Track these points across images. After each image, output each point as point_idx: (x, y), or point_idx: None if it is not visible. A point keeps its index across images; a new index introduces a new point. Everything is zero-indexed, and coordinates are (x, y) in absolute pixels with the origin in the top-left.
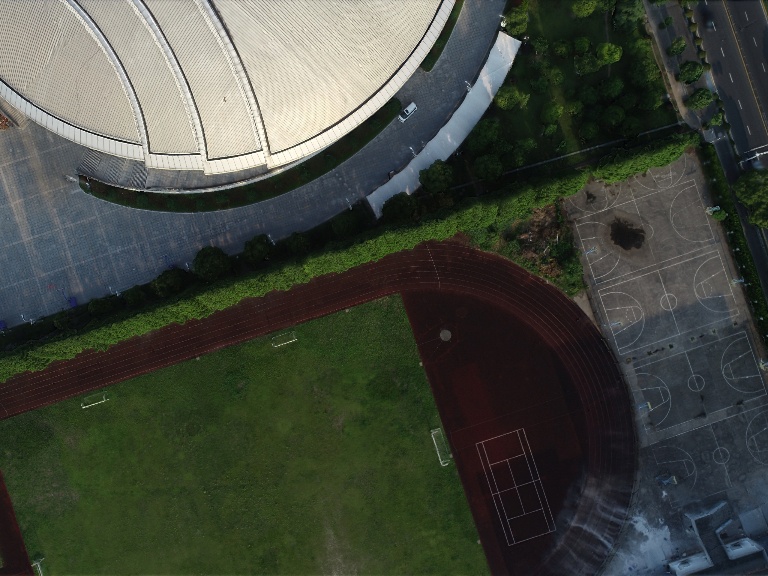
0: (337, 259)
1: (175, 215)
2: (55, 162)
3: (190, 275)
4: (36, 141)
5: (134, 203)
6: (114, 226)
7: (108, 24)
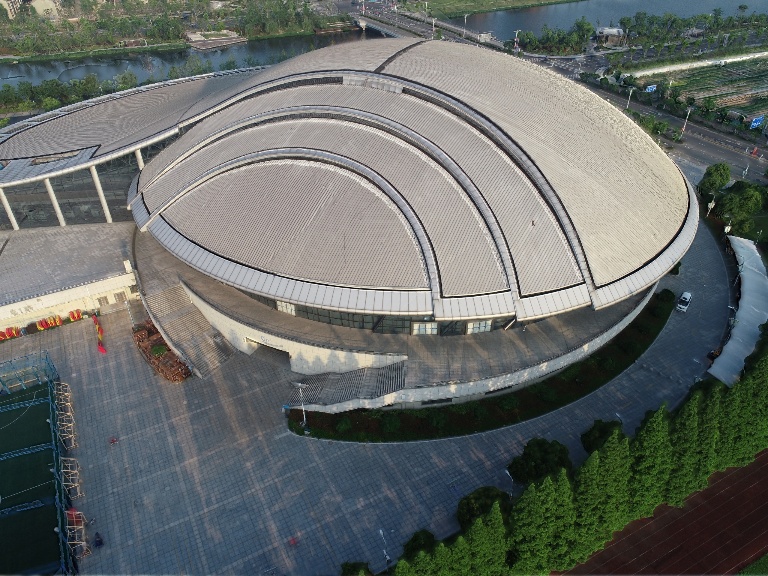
0: (765, 393)
1: (441, 442)
2: (250, 407)
3: (512, 498)
4: (223, 388)
5: (376, 433)
6: (347, 471)
7: (392, 171)
